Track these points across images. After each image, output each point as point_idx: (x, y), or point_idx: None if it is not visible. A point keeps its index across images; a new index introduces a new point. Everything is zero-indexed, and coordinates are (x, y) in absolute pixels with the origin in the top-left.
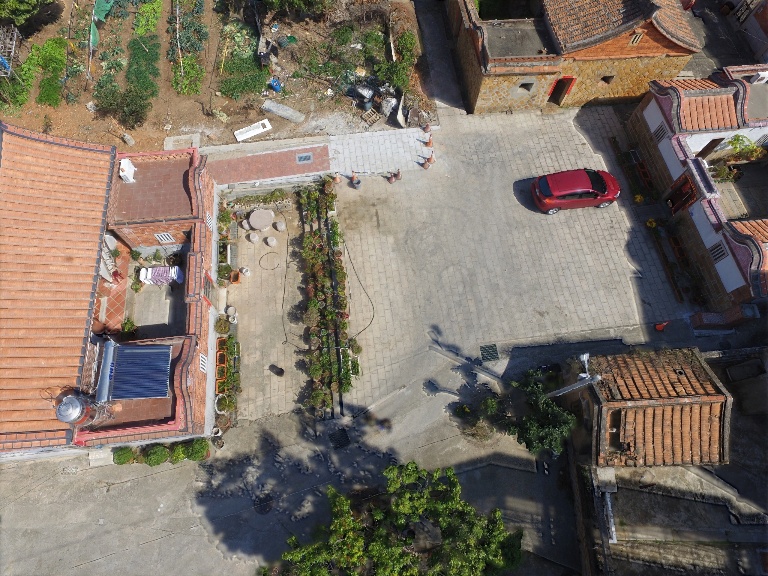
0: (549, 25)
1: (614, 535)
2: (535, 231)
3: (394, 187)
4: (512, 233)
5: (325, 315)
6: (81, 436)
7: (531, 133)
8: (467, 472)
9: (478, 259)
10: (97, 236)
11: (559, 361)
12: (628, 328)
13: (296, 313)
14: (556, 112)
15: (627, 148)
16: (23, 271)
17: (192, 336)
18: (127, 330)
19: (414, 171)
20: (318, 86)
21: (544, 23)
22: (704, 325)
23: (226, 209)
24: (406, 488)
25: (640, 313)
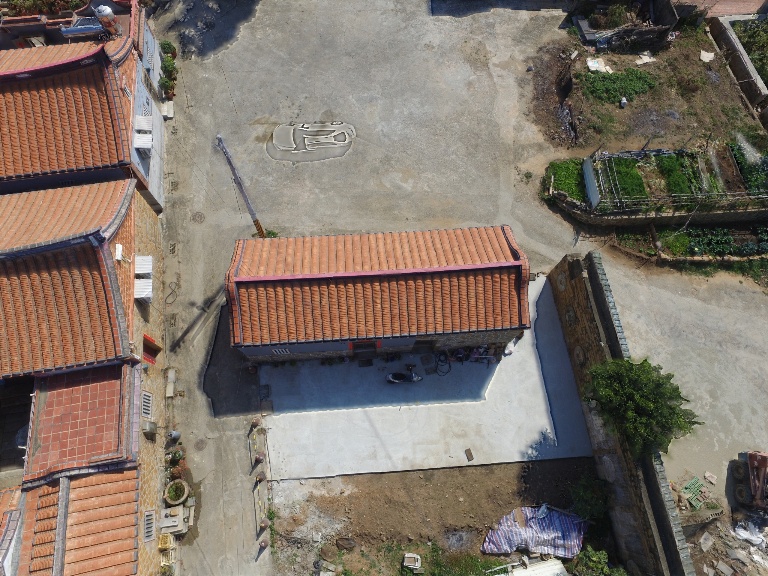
0: None
1: None
2: None
3: None
4: None
5: None
6: None
7: None
8: None
9: None
10: None
11: None
12: None
13: None
14: None
15: None
16: None
17: None
18: None
19: None
20: None
21: None
22: None
23: None
24: None
25: None
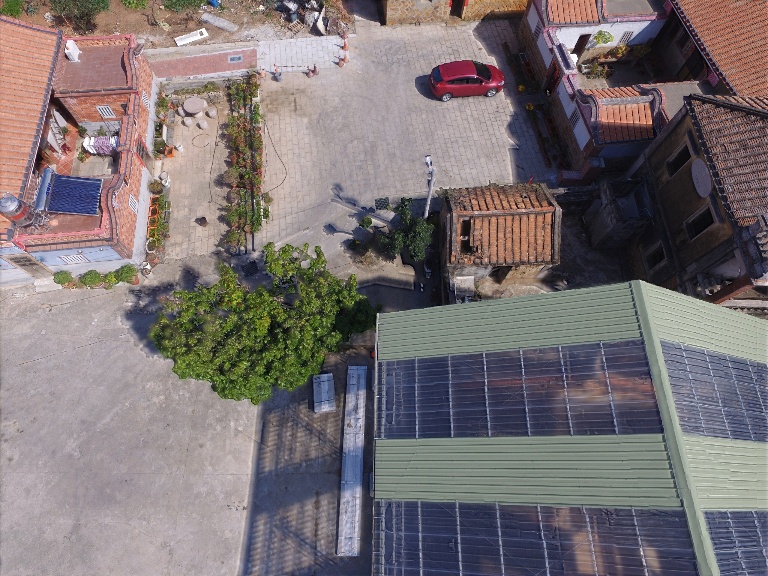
0: None
1: None
2: (431, 114)
3: (312, 80)
4: (411, 115)
5: (243, 175)
6: (21, 237)
7: (435, 40)
8: None
9: (379, 135)
10: (42, 95)
11: None
12: None
13: (221, 180)
14: (458, 24)
15: (517, 52)
16: None
17: (121, 174)
18: None
19: (330, 68)
20: (251, 3)
21: None
22: (564, 180)
23: None
24: None
25: (514, 175)
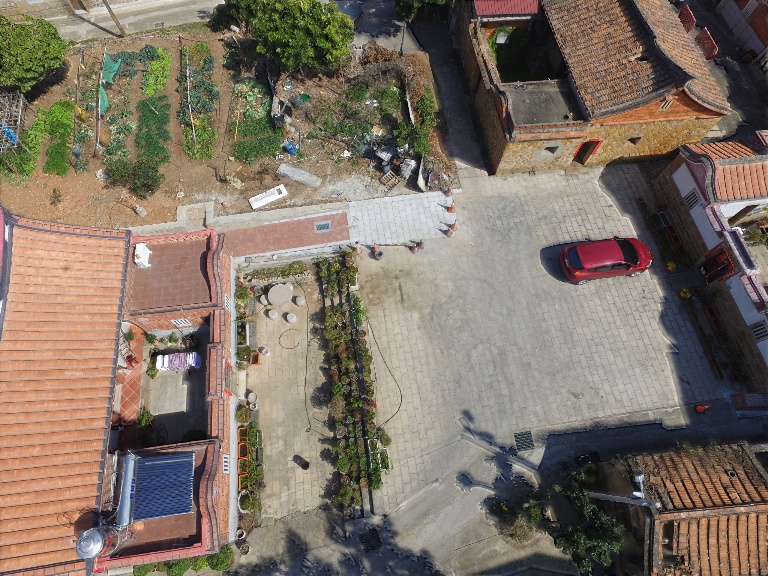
0: (574, 88)
1: None
2: (565, 303)
3: (417, 257)
4: (541, 306)
5: (351, 402)
6: (102, 563)
7: (555, 195)
8: None
9: (507, 336)
10: (113, 333)
11: (598, 449)
12: (667, 410)
13: (319, 396)
14: (580, 172)
15: (655, 210)
16: (37, 379)
17: (215, 440)
18: (144, 424)
19: (437, 239)
20: (334, 147)
21: (568, 84)
22: (748, 408)
23: (243, 284)
24: None
25: (679, 393)
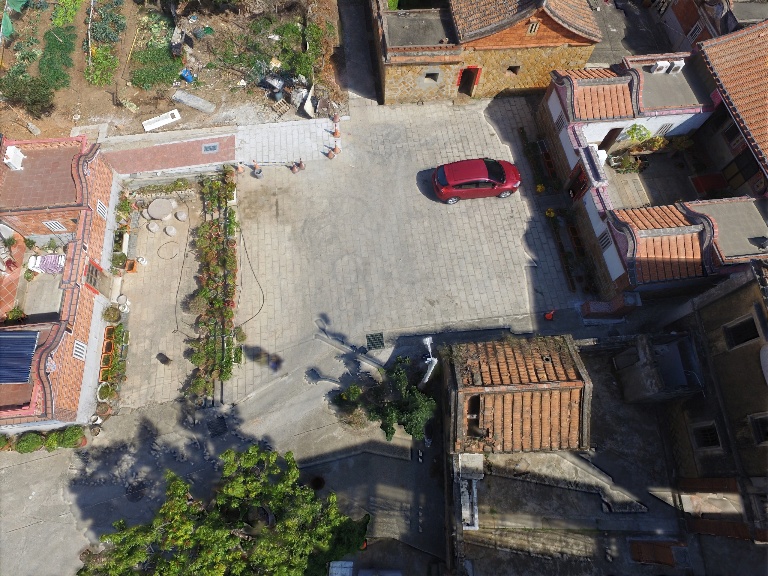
0: (452, 15)
1: (476, 522)
2: (434, 221)
3: (297, 177)
4: (411, 223)
5: (213, 303)
6: None
7: (440, 124)
8: (340, 460)
9: (374, 248)
10: None
11: None
12: (518, 317)
13: (190, 302)
14: (467, 103)
15: (535, 139)
16: None
17: (62, 322)
18: (11, 318)
19: (319, 161)
20: (231, 77)
21: (449, 13)
22: (591, 314)
23: (127, 198)
24: (243, 472)
25: (531, 302)
